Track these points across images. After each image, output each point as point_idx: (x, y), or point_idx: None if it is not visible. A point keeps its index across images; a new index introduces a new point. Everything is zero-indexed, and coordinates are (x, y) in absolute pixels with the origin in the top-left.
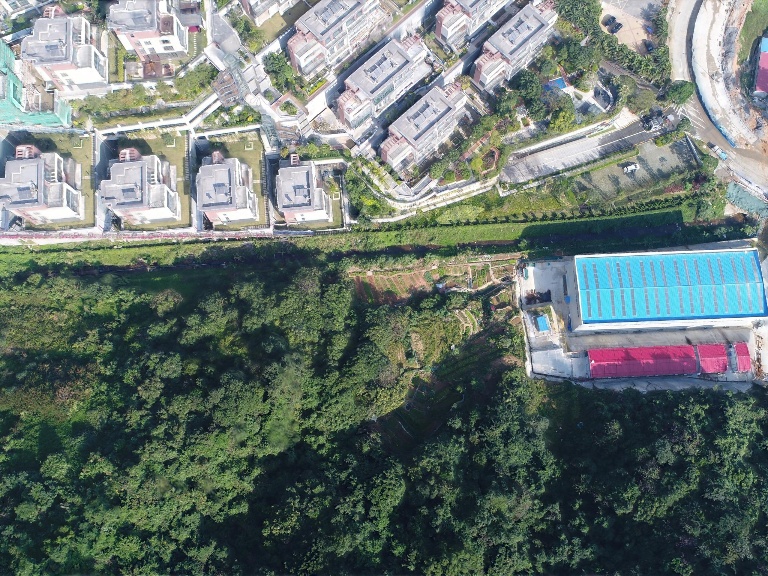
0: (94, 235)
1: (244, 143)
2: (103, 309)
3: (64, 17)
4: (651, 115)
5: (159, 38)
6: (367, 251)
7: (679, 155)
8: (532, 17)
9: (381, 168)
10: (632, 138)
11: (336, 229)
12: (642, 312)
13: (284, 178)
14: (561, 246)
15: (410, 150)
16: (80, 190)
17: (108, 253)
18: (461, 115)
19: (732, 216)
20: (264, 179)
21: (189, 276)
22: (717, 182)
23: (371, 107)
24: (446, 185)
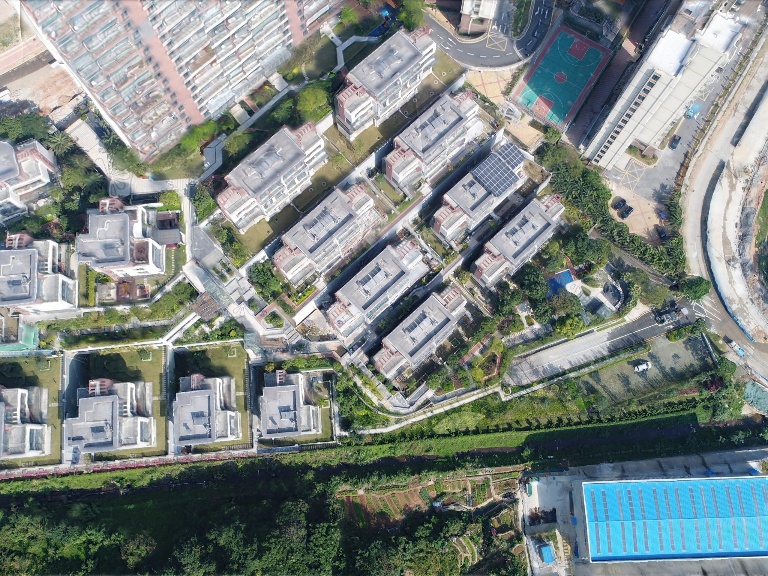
0: (61, 470)
1: (226, 353)
2: (69, 551)
3: (29, 242)
4: (663, 306)
5: (132, 267)
6: (358, 465)
7: (693, 352)
8: (537, 214)
9: (374, 377)
10: (643, 332)
11: (325, 442)
12: (655, 548)
13: (269, 398)
14: (567, 455)
15: (405, 360)
16: (46, 420)
17: (77, 479)
18: (460, 315)
19: (750, 416)
20: (248, 391)
21: (165, 502)
22: (734, 382)
23: (364, 317)
24: (444, 394)
